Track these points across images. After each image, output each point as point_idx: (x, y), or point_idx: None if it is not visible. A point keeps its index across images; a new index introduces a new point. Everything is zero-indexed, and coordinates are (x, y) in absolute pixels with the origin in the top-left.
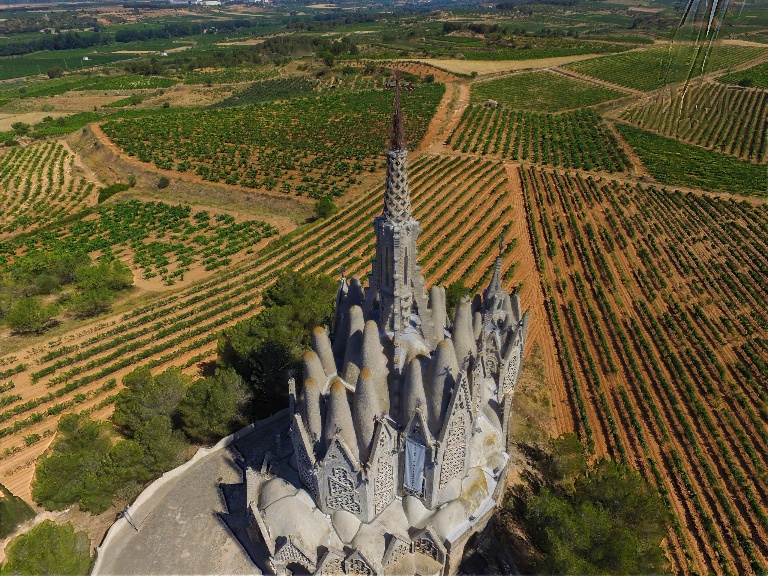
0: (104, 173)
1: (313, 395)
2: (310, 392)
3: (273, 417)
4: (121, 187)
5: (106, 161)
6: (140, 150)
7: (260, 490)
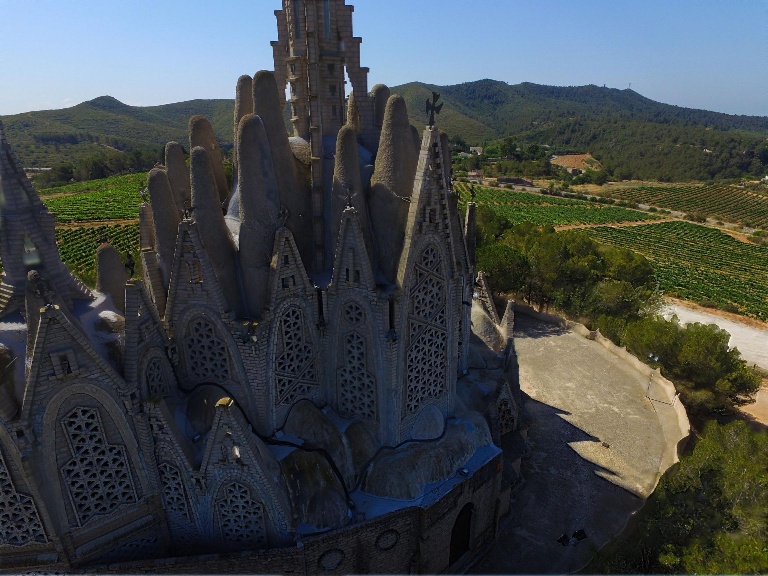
0: None
1: None
2: None
3: None
4: None
5: None
6: None
7: None
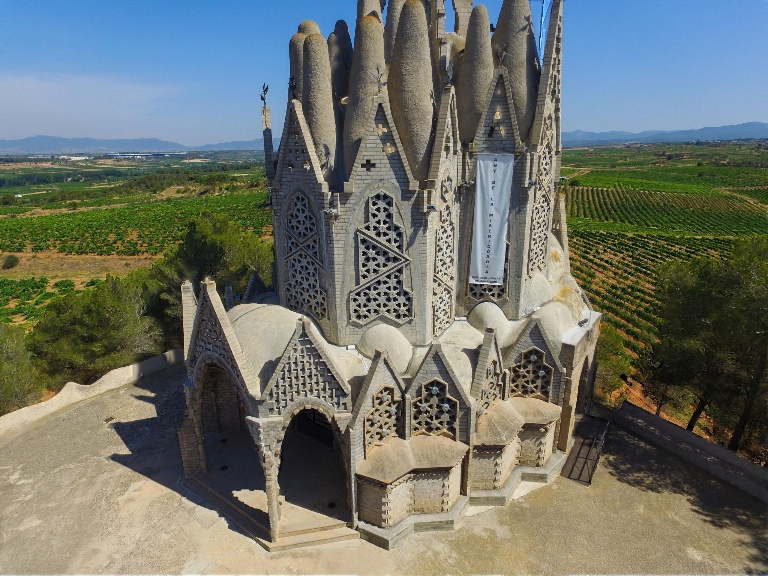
0: None
1: (322, 60)
2: (317, 50)
3: None
4: None
5: None
6: None
7: None
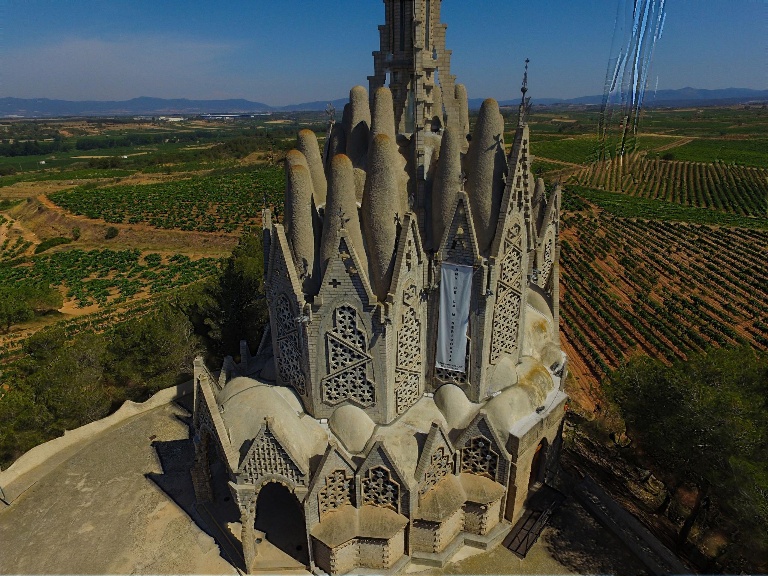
0: (45, 232)
1: (302, 188)
2: (298, 181)
3: None
4: (63, 240)
5: (49, 221)
6: (89, 210)
7: (215, 398)
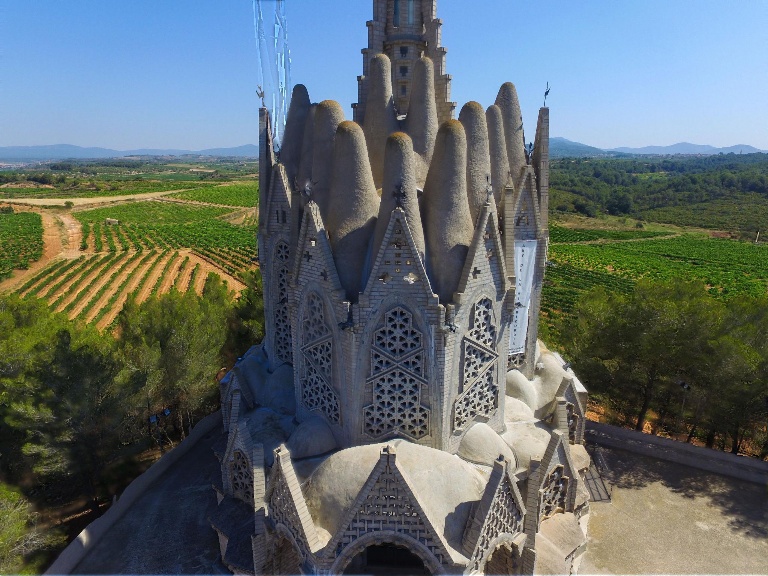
0: None
1: (412, 161)
2: (410, 152)
3: (118, 505)
4: None
5: None
6: None
7: (309, 504)
